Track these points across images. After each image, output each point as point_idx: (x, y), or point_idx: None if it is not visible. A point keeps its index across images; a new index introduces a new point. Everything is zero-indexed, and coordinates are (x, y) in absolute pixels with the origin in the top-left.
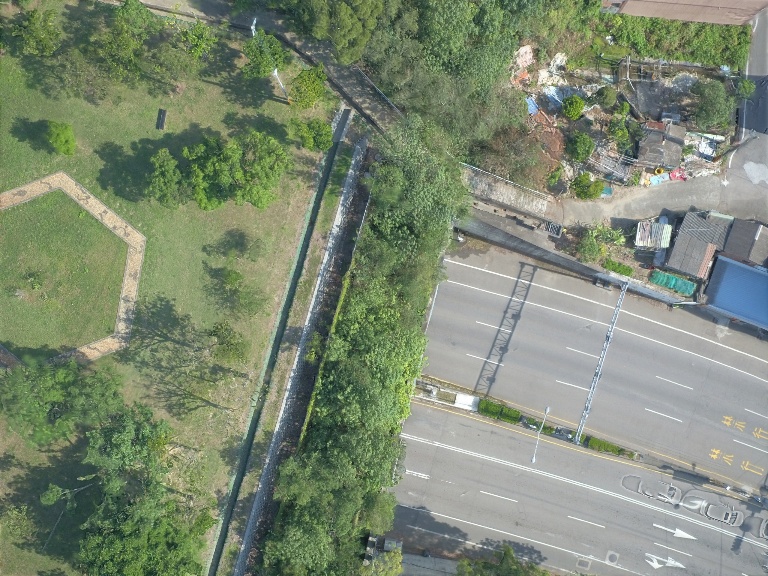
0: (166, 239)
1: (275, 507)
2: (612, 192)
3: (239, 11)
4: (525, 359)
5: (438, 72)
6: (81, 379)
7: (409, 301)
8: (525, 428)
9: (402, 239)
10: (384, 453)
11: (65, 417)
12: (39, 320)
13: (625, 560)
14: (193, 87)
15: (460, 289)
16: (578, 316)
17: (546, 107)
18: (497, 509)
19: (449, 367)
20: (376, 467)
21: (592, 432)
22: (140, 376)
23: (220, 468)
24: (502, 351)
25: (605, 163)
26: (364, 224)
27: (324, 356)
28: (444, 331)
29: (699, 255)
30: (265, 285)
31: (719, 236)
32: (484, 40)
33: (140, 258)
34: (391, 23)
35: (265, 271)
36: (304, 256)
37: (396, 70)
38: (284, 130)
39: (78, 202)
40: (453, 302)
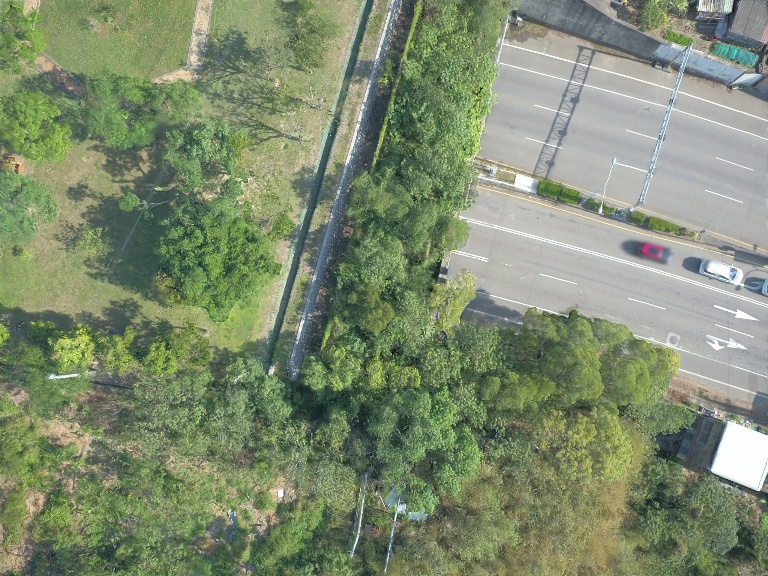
0: None
1: (344, 247)
2: None
3: None
4: (584, 142)
5: None
6: (160, 86)
7: (479, 37)
8: (584, 211)
9: None
10: (458, 171)
11: (138, 147)
12: (112, 53)
13: (686, 342)
14: None
15: (518, 73)
16: (637, 98)
17: None
18: (557, 291)
19: (508, 150)
20: (451, 182)
21: (652, 214)
22: (212, 107)
23: (292, 199)
24: (561, 134)
25: None
26: None
27: (396, 82)
28: (503, 115)
29: (762, 19)
30: (336, 19)
31: None
32: None
33: None
34: None
35: (336, 5)
36: None
37: None
38: None
39: None
40: (511, 86)
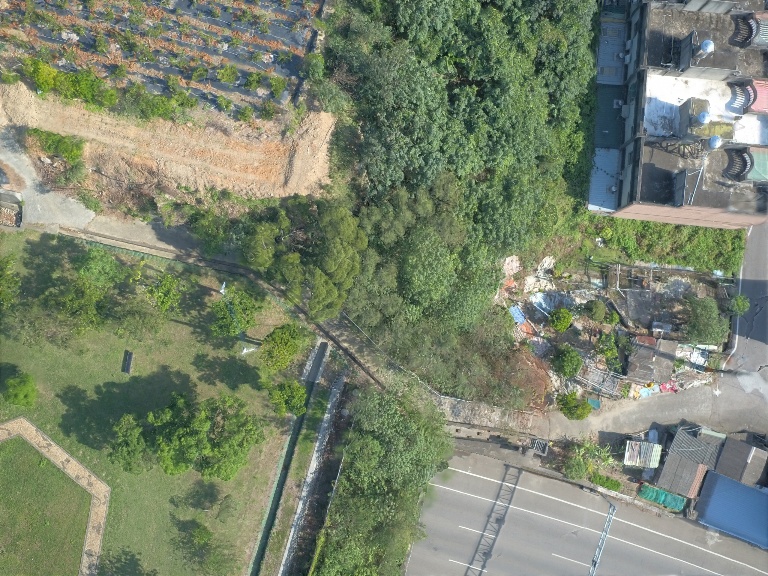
0: (131, 489)
1: None
2: (600, 405)
3: (209, 253)
4: (509, 565)
5: (418, 321)
6: None
7: None
8: None
9: (379, 495)
10: None
11: None
12: None
13: None
14: (160, 339)
15: (442, 492)
16: (564, 521)
17: (533, 316)
18: None
19: (430, 573)
20: None
21: None
22: None
23: None
24: (485, 557)
25: (593, 375)
26: (340, 477)
27: None
28: None
29: (689, 476)
30: (235, 538)
31: (710, 455)
32: (467, 271)
33: (104, 509)
34: (368, 281)
35: (236, 523)
36: (277, 503)
37: (374, 325)
38: (257, 373)
39: (39, 450)
40: (435, 506)
